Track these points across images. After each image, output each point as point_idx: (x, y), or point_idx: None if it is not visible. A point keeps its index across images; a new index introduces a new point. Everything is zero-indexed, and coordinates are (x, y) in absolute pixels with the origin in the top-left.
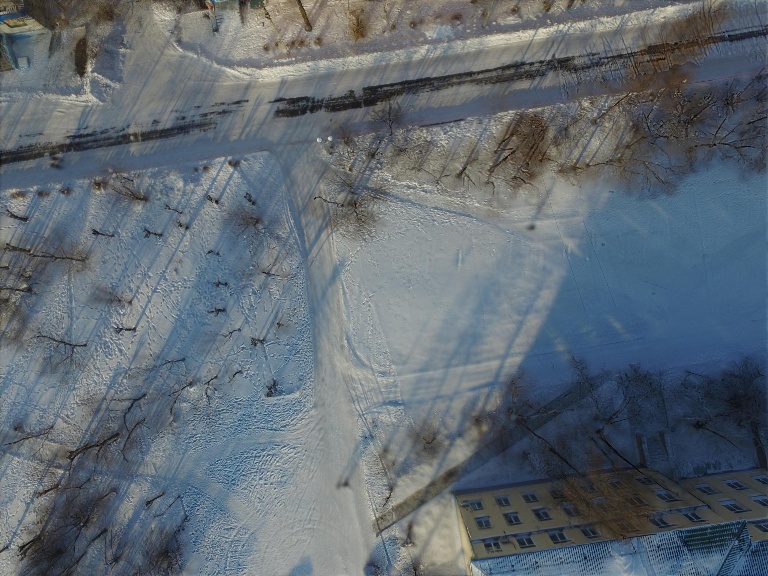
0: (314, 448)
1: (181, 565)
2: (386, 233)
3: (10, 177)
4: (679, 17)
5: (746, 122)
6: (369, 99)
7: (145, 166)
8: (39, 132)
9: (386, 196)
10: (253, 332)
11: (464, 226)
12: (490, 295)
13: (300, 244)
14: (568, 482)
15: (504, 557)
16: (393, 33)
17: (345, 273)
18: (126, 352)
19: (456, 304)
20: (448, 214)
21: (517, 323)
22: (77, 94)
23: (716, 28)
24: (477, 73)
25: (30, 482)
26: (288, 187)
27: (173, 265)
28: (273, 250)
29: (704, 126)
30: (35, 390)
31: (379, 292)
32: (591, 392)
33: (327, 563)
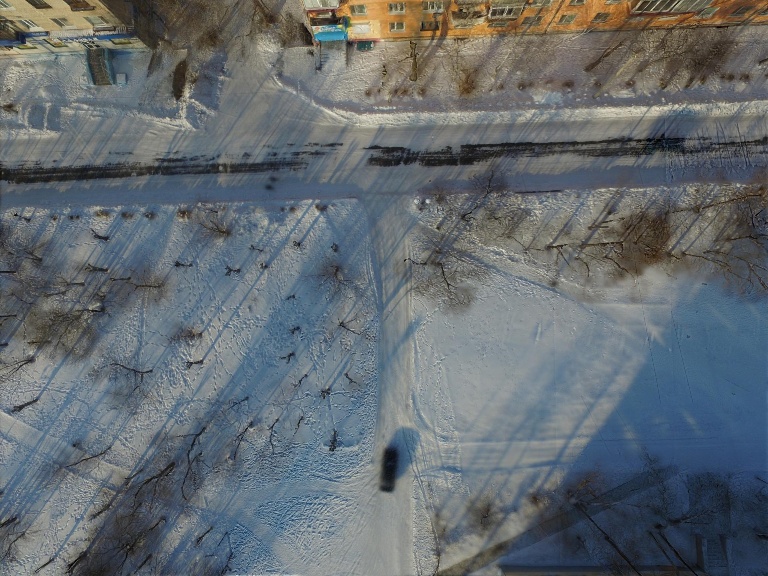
0: (366, 503)
1: None
2: (466, 297)
3: (95, 193)
4: None
5: None
6: (466, 157)
7: (231, 198)
8: (129, 151)
9: (471, 259)
10: (319, 380)
11: (547, 300)
12: (565, 374)
13: (377, 297)
14: (622, 575)
15: None
16: (499, 92)
17: (419, 332)
18: (191, 383)
19: (529, 378)
20: (532, 286)
21: (588, 405)
22: (171, 117)
23: None
24: (581, 144)
25: (82, 499)
26: (372, 237)
27: (247, 302)
28: (350, 300)
29: None
30: (97, 409)
31: (452, 356)
32: (663, 494)
33: None
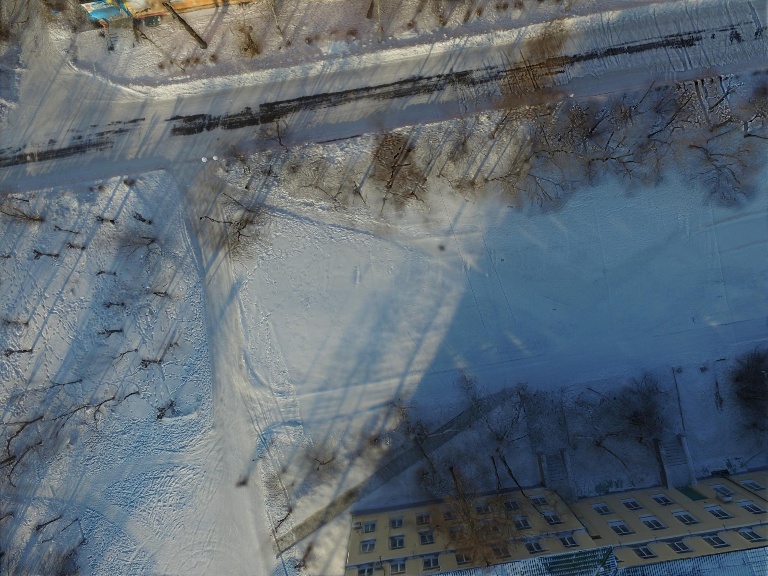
0: (213, 469)
1: None
2: (283, 251)
3: None
4: (577, 29)
5: (646, 135)
6: (266, 116)
7: (41, 186)
8: None
9: (283, 214)
10: (150, 352)
11: (362, 243)
12: (389, 313)
13: (197, 263)
14: (465, 502)
15: None
16: (289, 49)
17: (243, 292)
18: (23, 374)
19: (354, 322)
20: (346, 231)
21: (416, 341)
22: None
23: (615, 40)
24: (374, 88)
25: None
26: (185, 206)
27: (69, 286)
28: (169, 269)
29: (603, 139)
30: None
31: (277, 311)
32: (479, 412)
33: None
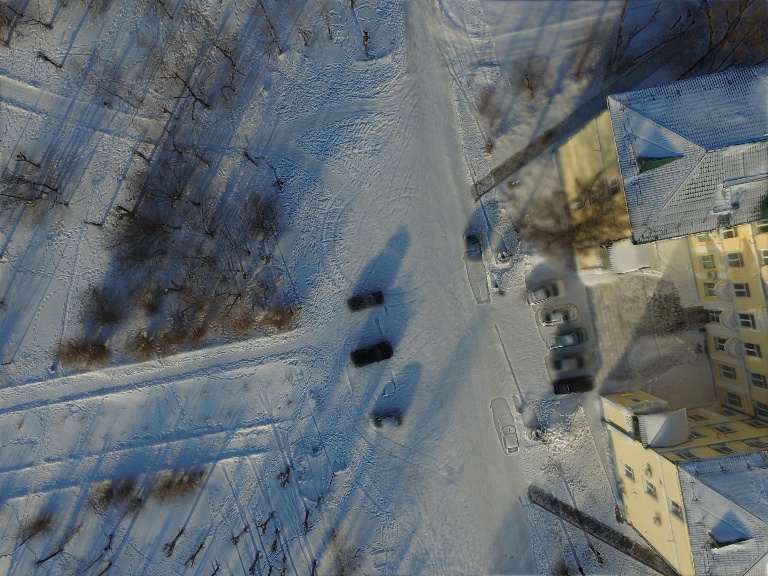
0: (408, 115)
1: (277, 236)
2: None
3: None
4: None
5: None
6: None
7: None
8: None
9: None
10: None
11: None
12: None
13: None
14: None
15: (643, 89)
16: None
17: None
18: (213, 23)
19: None
20: None
21: None
22: None
23: None
24: None
25: (121, 159)
26: None
27: None
28: None
29: None
30: (123, 65)
31: None
32: (706, 1)
33: (425, 231)
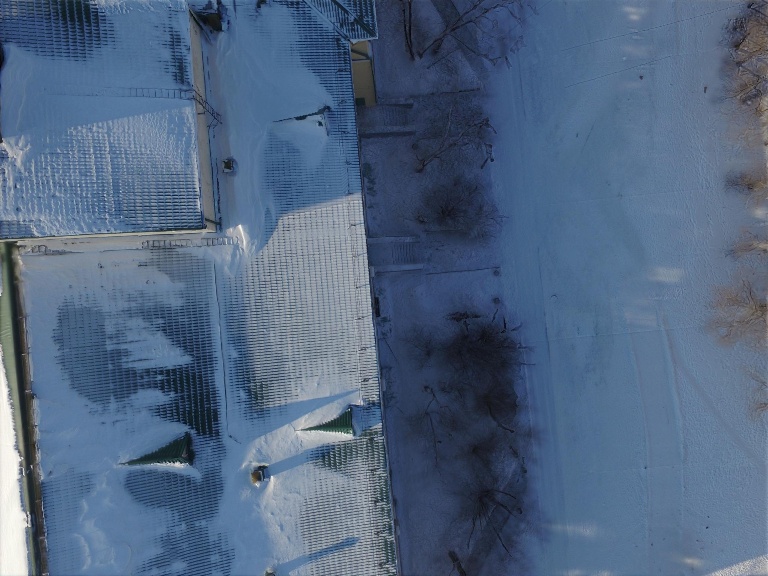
0: None
1: None
2: None
3: None
4: None
5: None
6: None
7: None
8: None
9: None
10: None
11: None
12: None
13: None
14: None
15: None
16: None
17: None
18: None
19: None
20: None
21: None
22: None
23: None
24: None
25: None
26: None
27: None
28: None
29: None
30: None
31: None
32: None
33: None
